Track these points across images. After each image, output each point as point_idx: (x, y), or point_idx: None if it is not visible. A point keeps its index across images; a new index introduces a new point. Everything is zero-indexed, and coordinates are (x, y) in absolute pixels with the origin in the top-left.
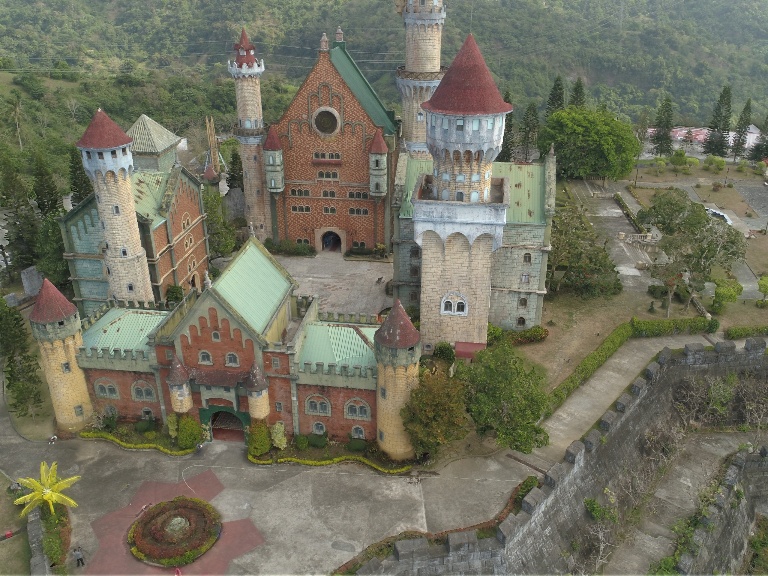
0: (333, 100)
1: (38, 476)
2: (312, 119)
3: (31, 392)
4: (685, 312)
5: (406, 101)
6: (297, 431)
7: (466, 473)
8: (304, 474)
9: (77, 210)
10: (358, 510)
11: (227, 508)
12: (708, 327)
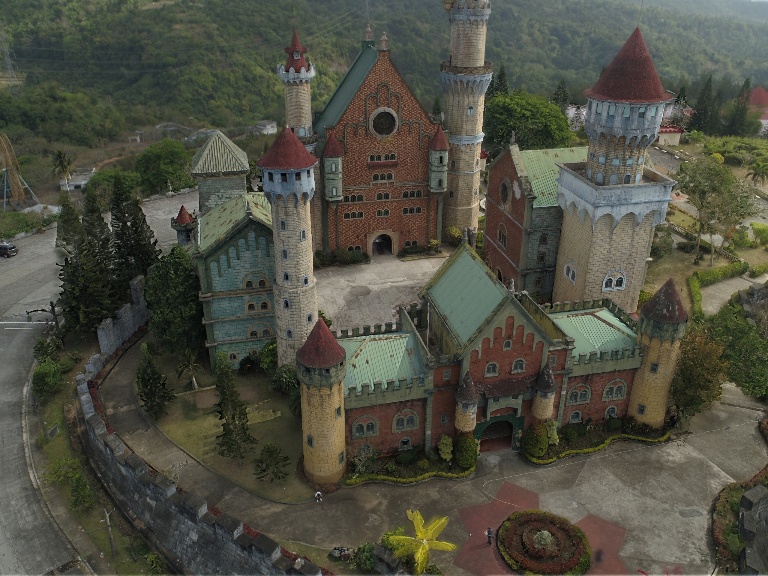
0: (391, 100)
1: (345, 536)
2: (370, 121)
3: (276, 451)
4: (719, 260)
5: (455, 96)
6: (560, 424)
7: (710, 426)
8: (590, 462)
9: (223, 243)
10: (667, 480)
11: (562, 511)
12: (743, 270)
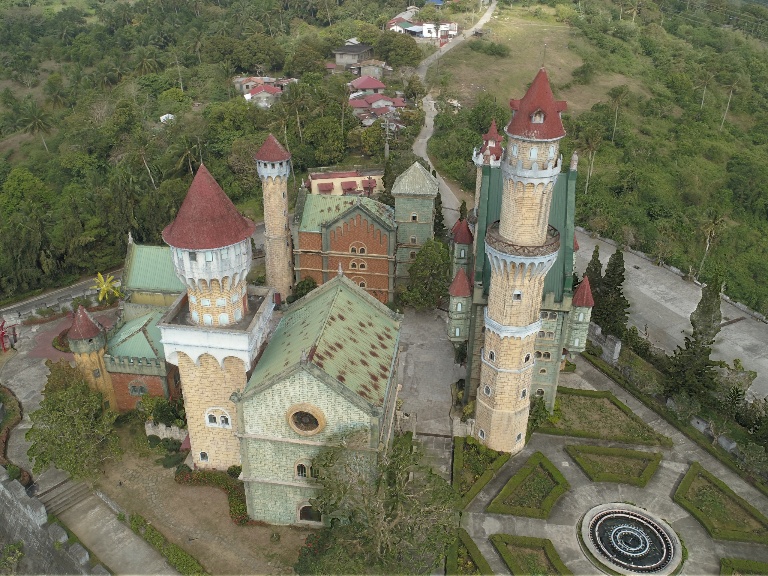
0: None
1: None
2: None
3: None
4: None
5: None
6: None
7: None
8: None
9: None
10: None
11: None
12: None
